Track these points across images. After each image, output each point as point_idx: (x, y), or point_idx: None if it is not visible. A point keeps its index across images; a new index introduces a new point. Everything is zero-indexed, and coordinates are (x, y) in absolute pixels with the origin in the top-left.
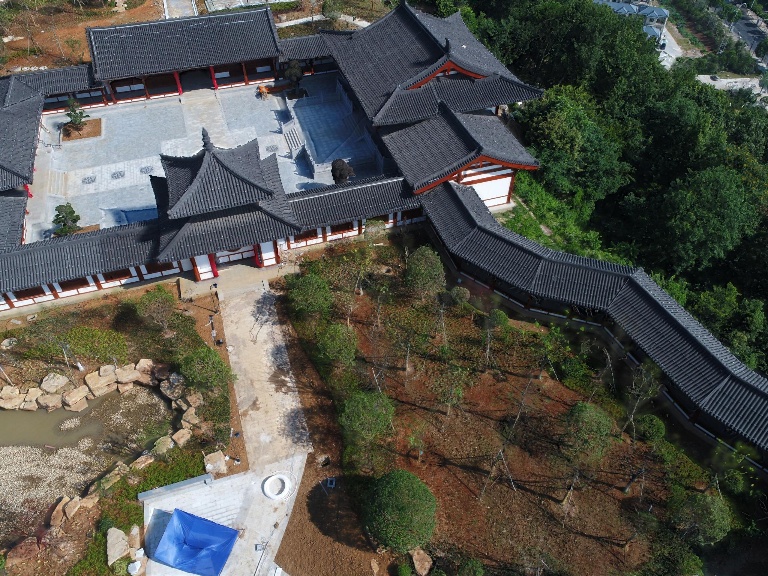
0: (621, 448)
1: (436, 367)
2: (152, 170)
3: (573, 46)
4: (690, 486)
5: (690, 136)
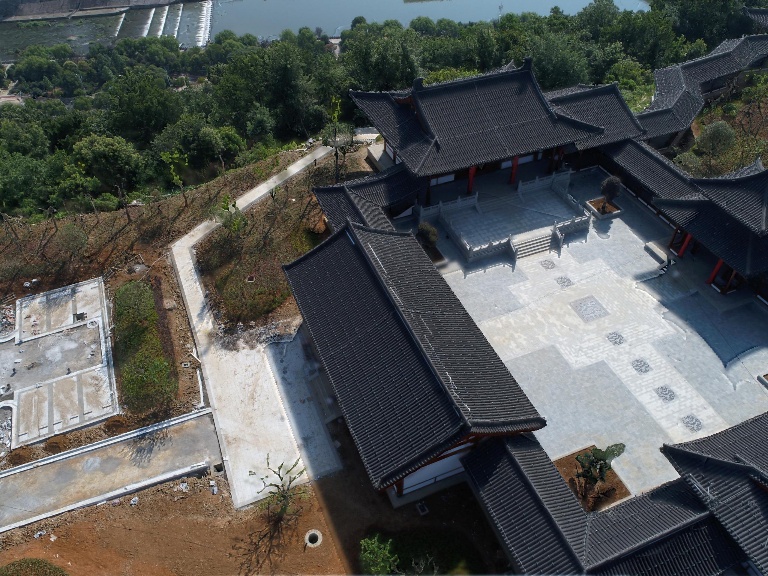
0: (763, 104)
1: (764, 154)
2: (639, 360)
3: (294, 88)
4: (767, 91)
5: (485, 46)
